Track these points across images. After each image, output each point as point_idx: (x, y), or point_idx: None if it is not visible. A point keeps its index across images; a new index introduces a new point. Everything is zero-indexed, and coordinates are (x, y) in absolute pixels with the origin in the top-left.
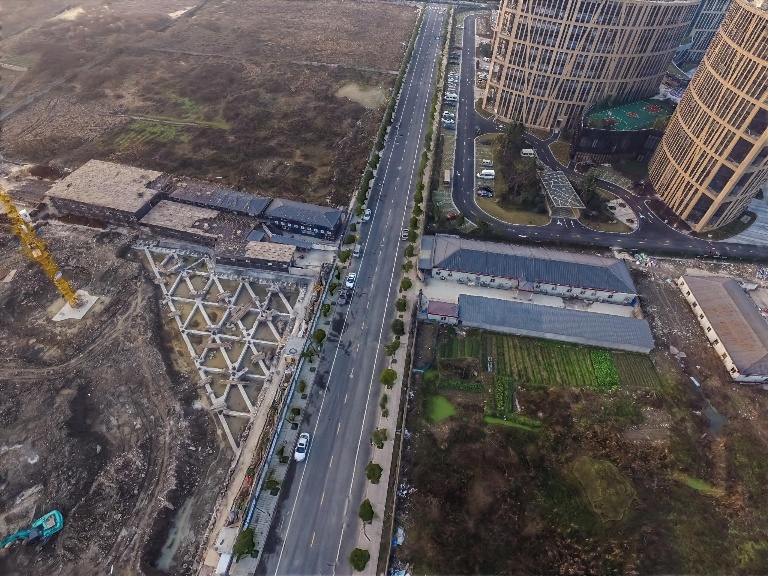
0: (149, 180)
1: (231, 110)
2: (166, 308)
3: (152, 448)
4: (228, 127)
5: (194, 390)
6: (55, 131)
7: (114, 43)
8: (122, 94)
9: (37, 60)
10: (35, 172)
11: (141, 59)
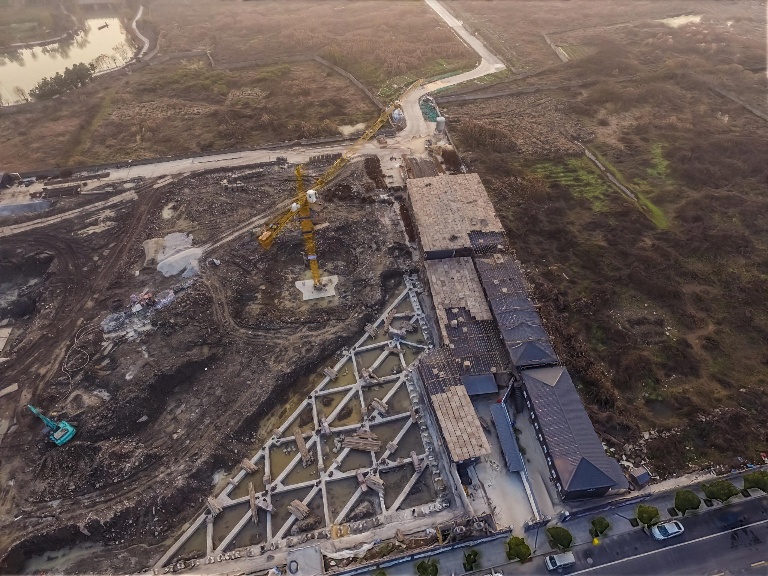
0: (482, 229)
1: (699, 208)
2: (338, 359)
3: (150, 467)
4: (666, 226)
5: (235, 461)
6: (508, 127)
7: (678, 65)
8: (610, 122)
9: (587, 56)
10: (445, 155)
11: (683, 93)
